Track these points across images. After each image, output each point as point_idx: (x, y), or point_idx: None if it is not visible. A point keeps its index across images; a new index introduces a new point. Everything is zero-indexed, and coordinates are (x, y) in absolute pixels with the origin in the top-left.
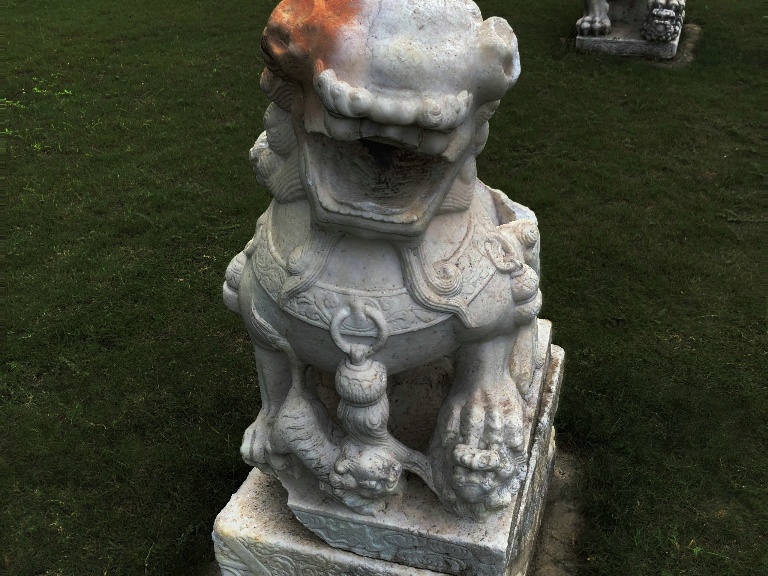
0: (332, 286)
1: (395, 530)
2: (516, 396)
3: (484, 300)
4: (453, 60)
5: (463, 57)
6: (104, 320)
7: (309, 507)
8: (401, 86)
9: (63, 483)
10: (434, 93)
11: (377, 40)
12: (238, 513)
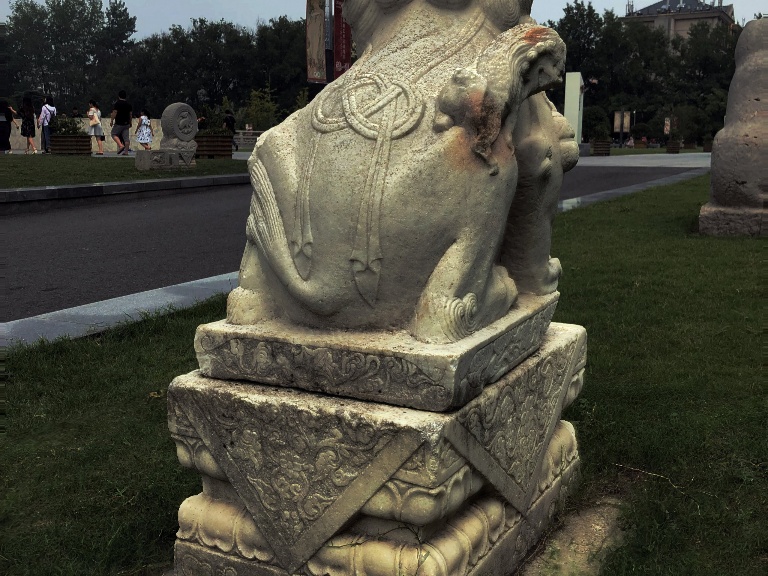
0: None
1: None
2: None
3: None
4: None
5: None
6: None
7: None
8: None
9: None
10: None
11: None
12: None
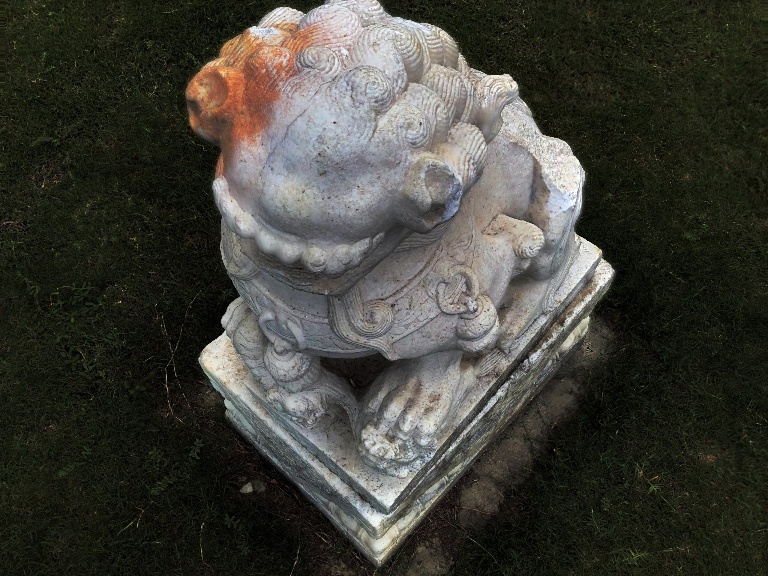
0: (264, 290)
1: (314, 446)
2: (454, 389)
3: (415, 339)
4: (352, 215)
5: (368, 210)
6: (246, 9)
7: (257, 394)
8: (285, 230)
9: (154, 197)
10: (323, 242)
11: (272, 173)
12: (222, 351)
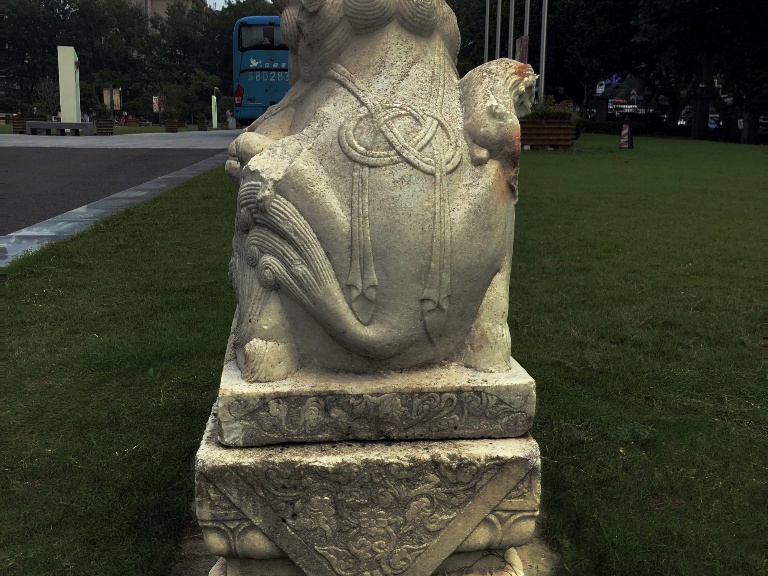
0: None
1: None
2: None
3: None
4: None
5: None
6: None
7: None
8: None
9: None
10: None
11: None
12: None
